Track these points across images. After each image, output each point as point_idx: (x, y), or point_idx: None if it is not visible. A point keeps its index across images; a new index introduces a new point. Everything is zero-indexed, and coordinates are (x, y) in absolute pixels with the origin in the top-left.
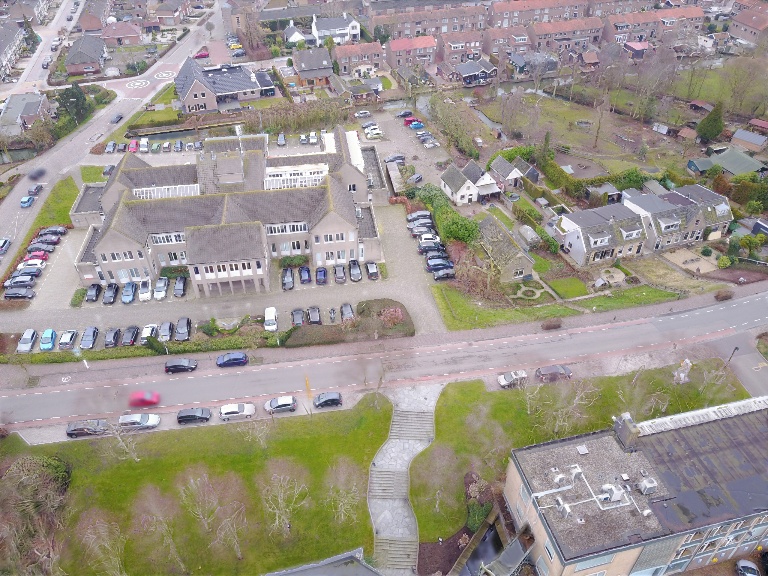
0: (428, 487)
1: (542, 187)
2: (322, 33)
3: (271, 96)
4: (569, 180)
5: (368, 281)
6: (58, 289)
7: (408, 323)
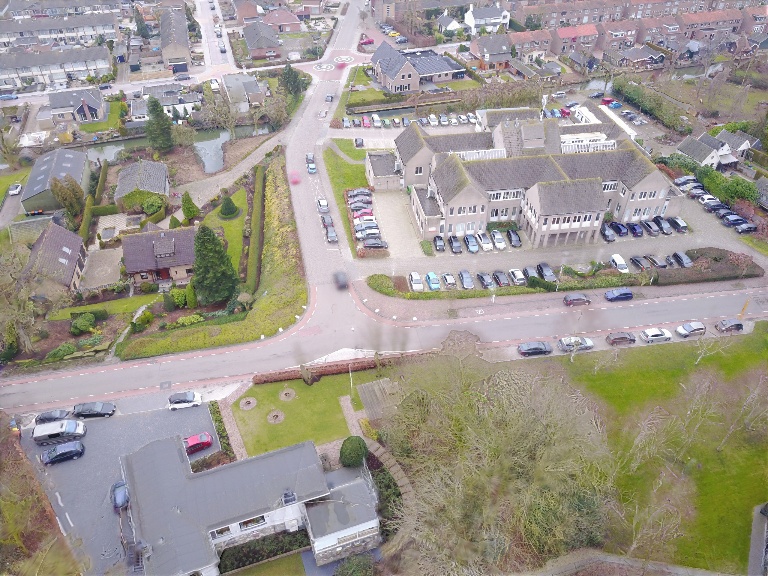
0: None
1: None
2: (478, 22)
3: (460, 78)
4: None
5: (678, 234)
6: (402, 241)
7: (756, 265)
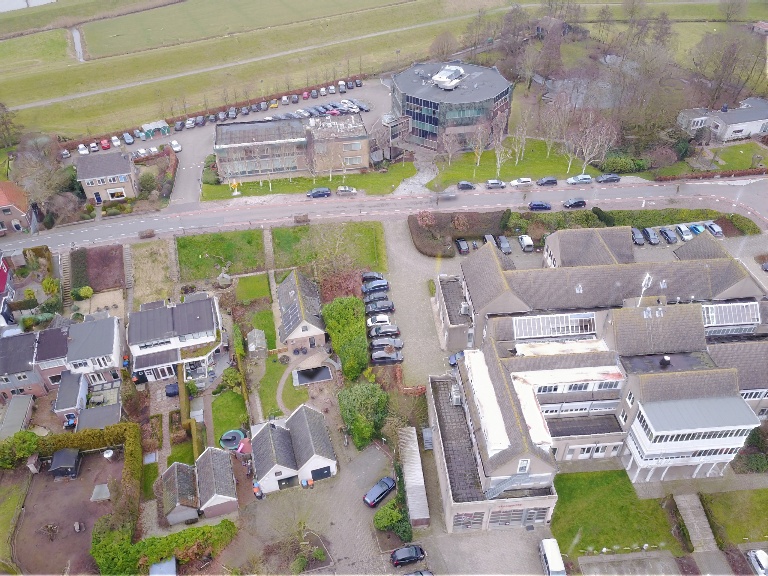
0: (407, 170)
1: None
2: None
3: None
4: None
5: None
6: None
7: (413, 219)
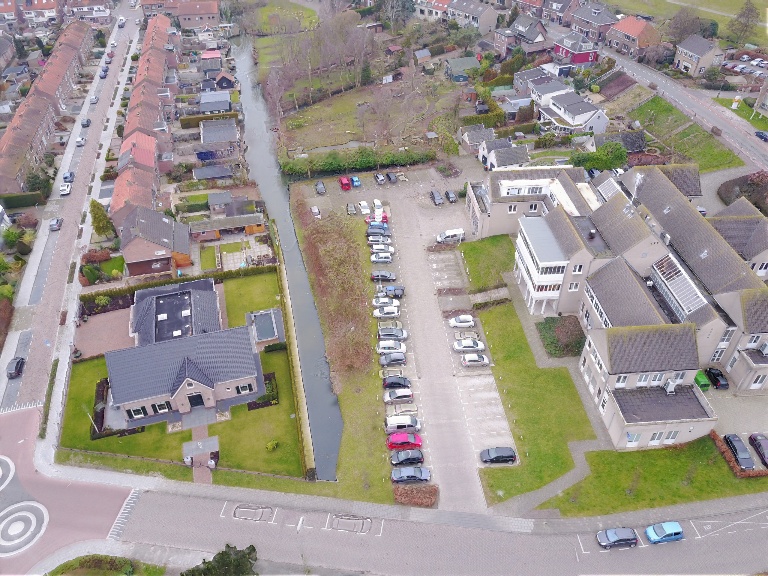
0: None
1: None
2: None
3: None
4: (500, 115)
5: None
6: None
7: None
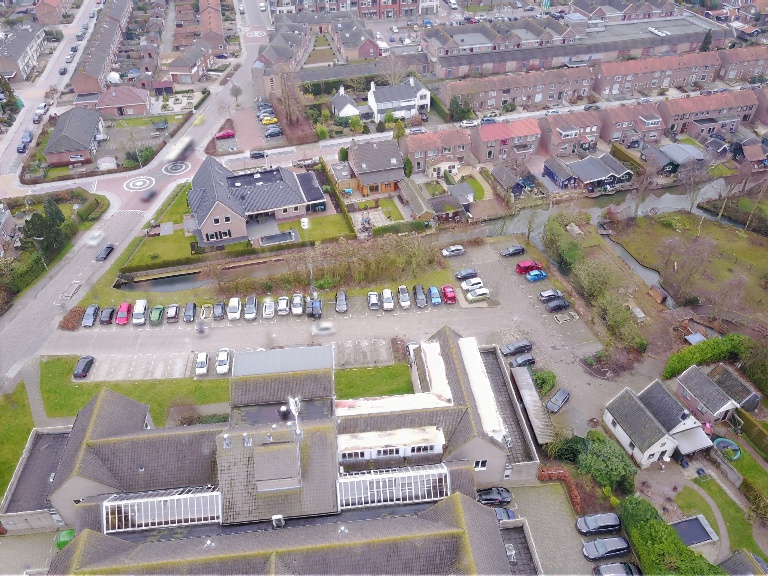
0: None
1: (767, 422)
2: (382, 106)
3: (320, 211)
4: None
5: None
6: None
7: None
